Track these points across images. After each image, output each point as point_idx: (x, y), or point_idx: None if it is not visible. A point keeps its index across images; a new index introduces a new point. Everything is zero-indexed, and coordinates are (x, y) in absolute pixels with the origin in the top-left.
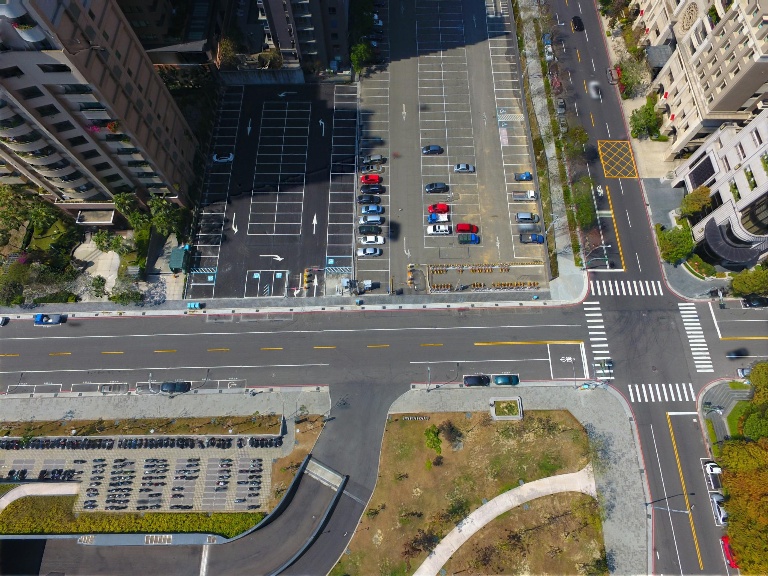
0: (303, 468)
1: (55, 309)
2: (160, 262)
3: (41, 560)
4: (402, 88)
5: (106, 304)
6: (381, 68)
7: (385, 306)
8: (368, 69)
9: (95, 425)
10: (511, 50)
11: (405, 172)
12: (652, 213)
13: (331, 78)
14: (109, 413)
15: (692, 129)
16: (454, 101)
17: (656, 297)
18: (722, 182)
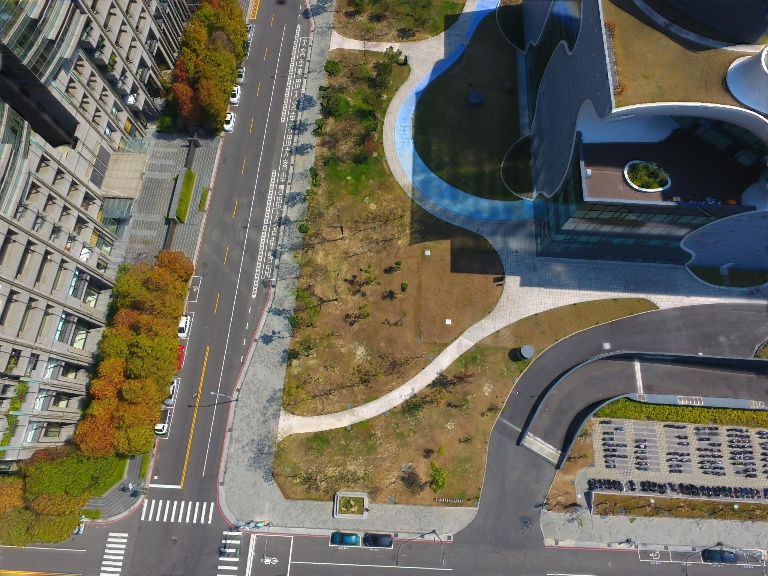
0: (563, 456)
1: None
2: None
3: None
4: None
5: None
6: None
7: None
8: None
9: None
10: None
11: None
12: None
13: None
14: None
15: None
16: None
17: None
18: None
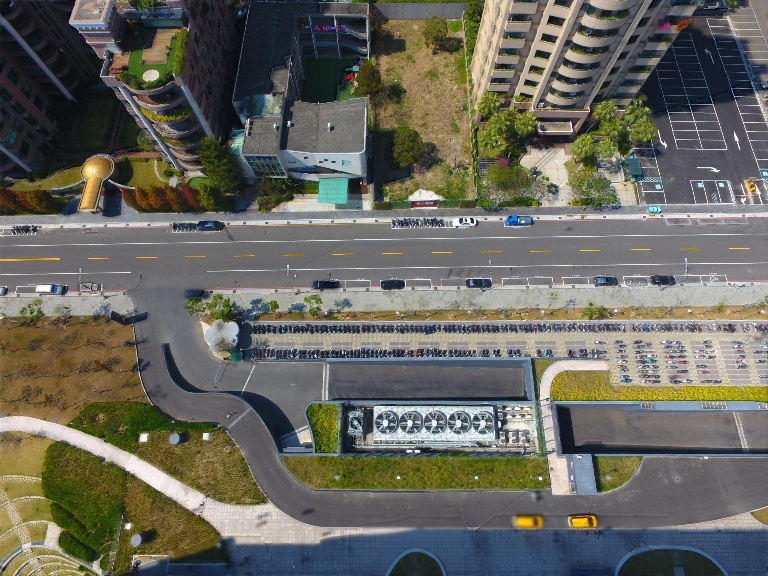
0: None
1: (519, 212)
2: None
3: (572, 431)
4: None
5: (566, 208)
6: (743, 4)
7: None
8: (731, 5)
9: (602, 312)
10: None
11: None
12: None
13: None
14: (608, 302)
15: None
16: None
17: None
18: None
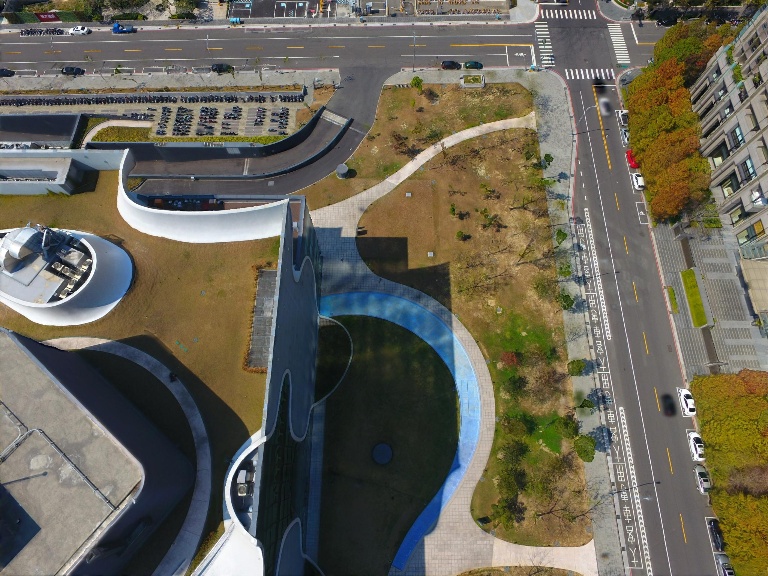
0: (319, 114)
1: (127, 24)
2: None
3: None
4: None
5: (167, 22)
6: None
7: (382, 24)
8: None
9: (162, 89)
10: None
11: None
12: None
13: None
14: (172, 84)
15: None
16: None
17: (591, 20)
18: None
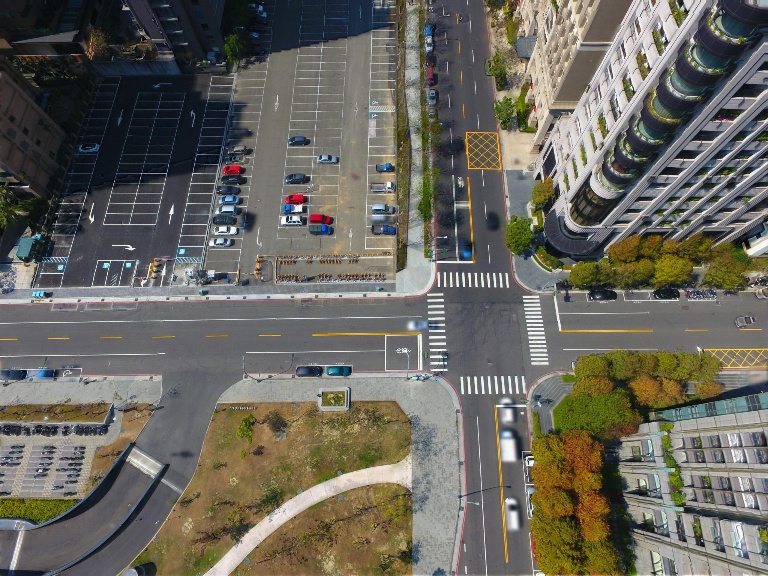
0: (125, 456)
1: None
2: (14, 251)
3: None
4: (278, 79)
5: None
6: (261, 59)
7: (229, 296)
8: (248, 60)
9: None
10: (393, 41)
11: (269, 163)
12: (510, 205)
13: (209, 69)
14: None
15: (544, 120)
16: (328, 92)
17: (501, 289)
18: (559, 173)
